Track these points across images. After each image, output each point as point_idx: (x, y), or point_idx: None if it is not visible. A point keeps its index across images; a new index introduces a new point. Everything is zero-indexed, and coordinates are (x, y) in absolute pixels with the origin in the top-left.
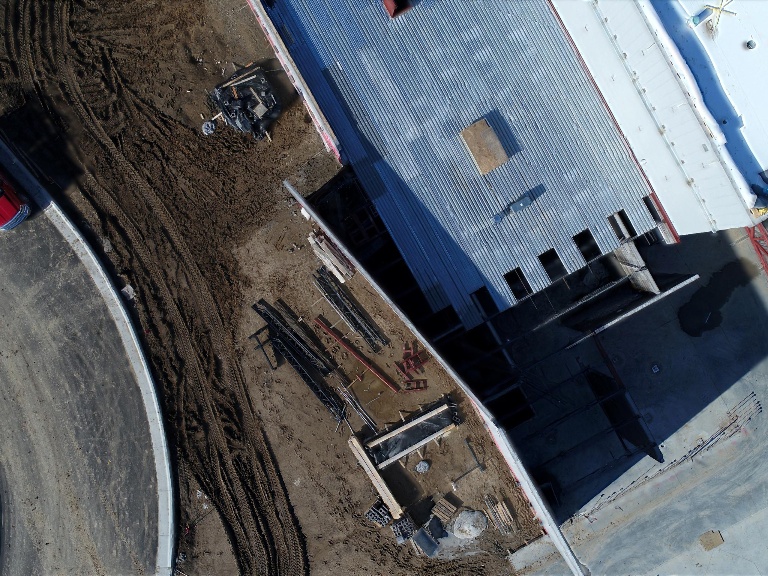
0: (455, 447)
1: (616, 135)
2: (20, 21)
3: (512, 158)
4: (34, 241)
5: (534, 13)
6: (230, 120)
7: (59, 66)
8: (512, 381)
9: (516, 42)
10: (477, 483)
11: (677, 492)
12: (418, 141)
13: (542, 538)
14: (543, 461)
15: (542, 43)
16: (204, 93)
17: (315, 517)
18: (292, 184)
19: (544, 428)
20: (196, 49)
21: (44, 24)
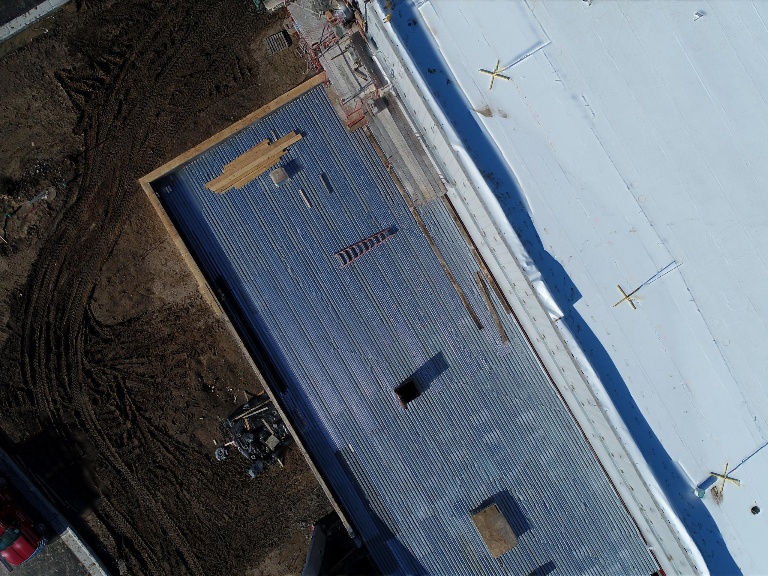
0: None
1: (623, 514)
2: (36, 350)
3: (522, 536)
4: (51, 565)
5: (541, 397)
6: (243, 451)
7: (74, 394)
8: None
9: (524, 425)
10: None
11: None
12: (429, 520)
13: None
14: None
15: (549, 426)
16: (217, 419)
17: None
18: (304, 508)
19: None
20: (208, 377)
21: (59, 353)
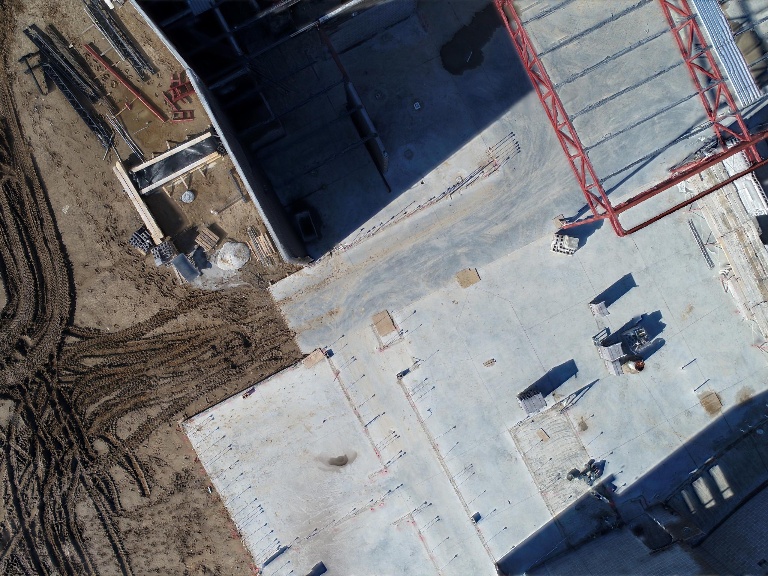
0: (220, 178)
1: None
2: None
3: None
4: None
5: None
6: None
7: None
8: (238, 67)
9: None
10: (241, 215)
11: (436, 229)
12: None
13: (302, 270)
14: (305, 193)
15: None
16: None
17: (82, 245)
18: None
19: (306, 161)
20: None
21: None
